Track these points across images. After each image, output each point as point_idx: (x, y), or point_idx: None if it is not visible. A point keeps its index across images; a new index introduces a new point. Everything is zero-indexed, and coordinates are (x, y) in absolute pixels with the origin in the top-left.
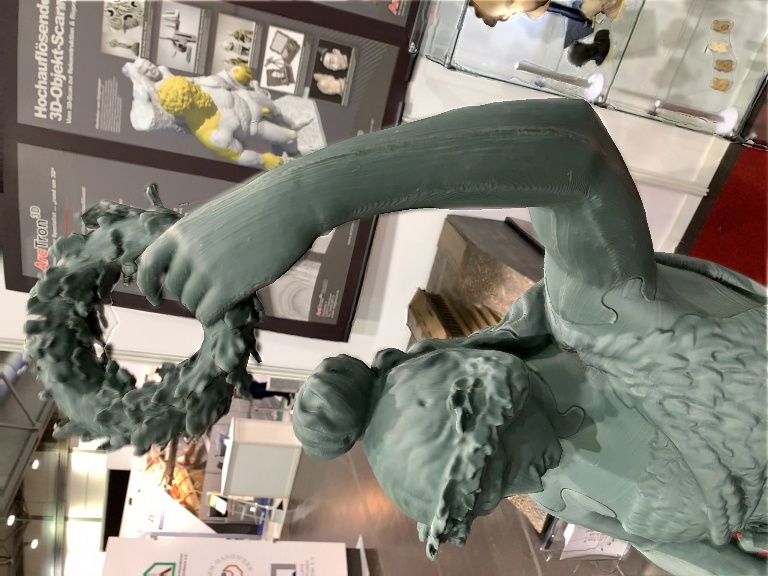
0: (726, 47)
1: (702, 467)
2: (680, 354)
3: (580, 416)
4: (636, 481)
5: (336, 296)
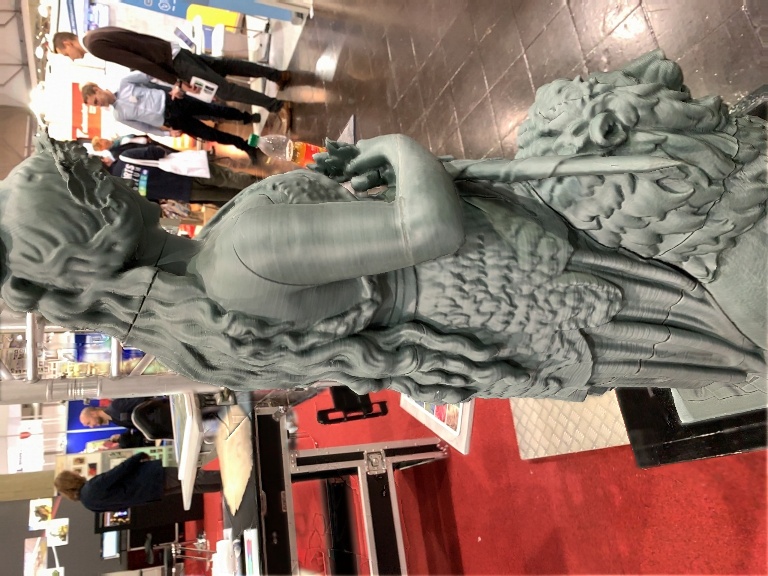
0: None
1: None
2: None
3: None
4: None
5: None
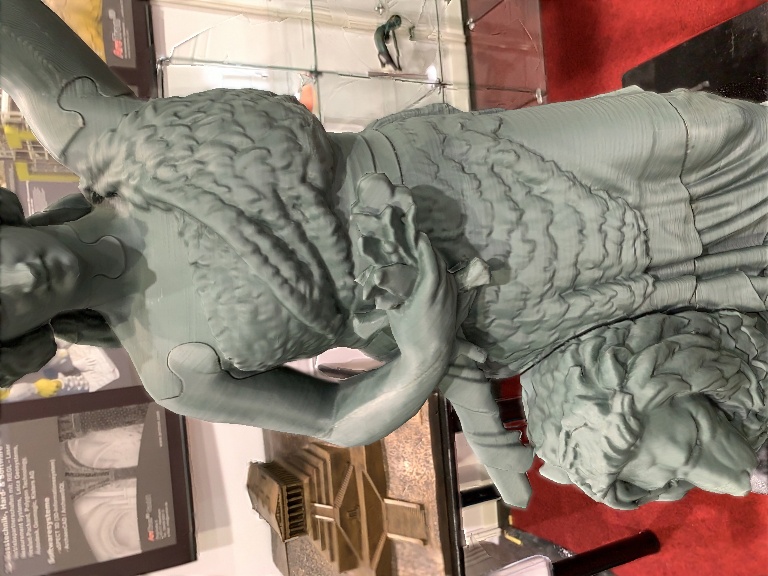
0: None
1: (208, 213)
2: (147, 125)
3: (116, 245)
4: (192, 284)
5: (166, 510)
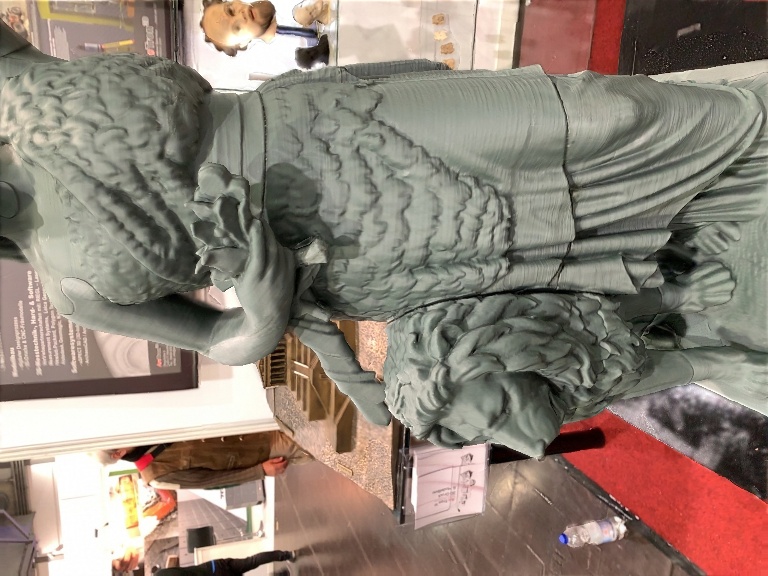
0: (446, 34)
1: (70, 182)
2: (25, 91)
3: (9, 191)
4: None
5: None
